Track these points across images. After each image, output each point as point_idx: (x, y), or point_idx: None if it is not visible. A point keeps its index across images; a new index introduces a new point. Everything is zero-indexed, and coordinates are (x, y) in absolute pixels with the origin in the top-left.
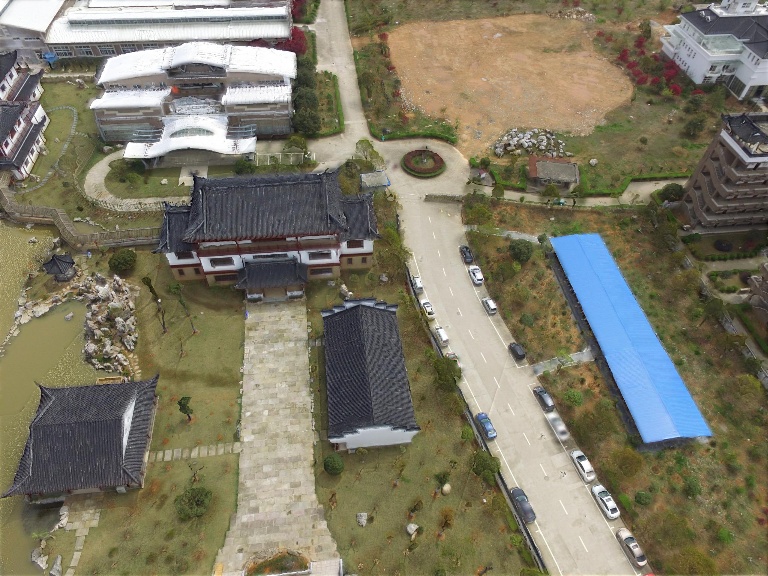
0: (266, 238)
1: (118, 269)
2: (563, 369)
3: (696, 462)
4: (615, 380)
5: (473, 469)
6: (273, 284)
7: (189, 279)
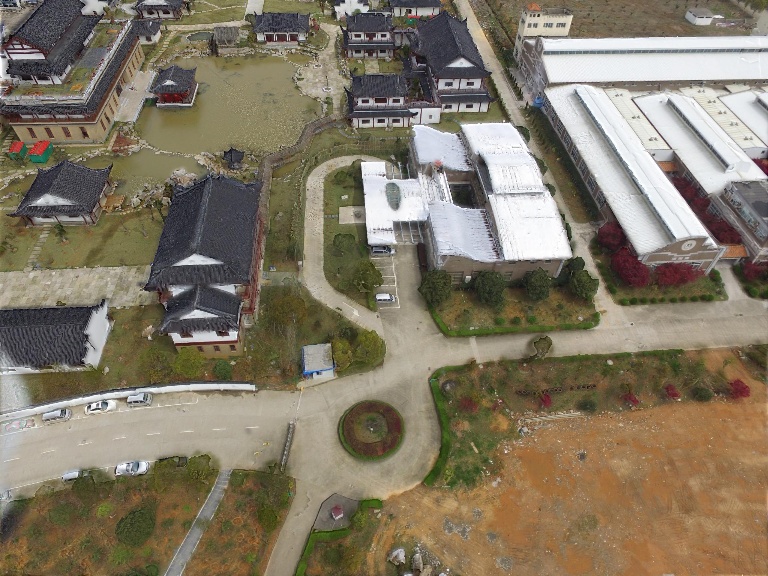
0: None
1: None
2: None
3: None
4: None
5: None
6: None
7: None
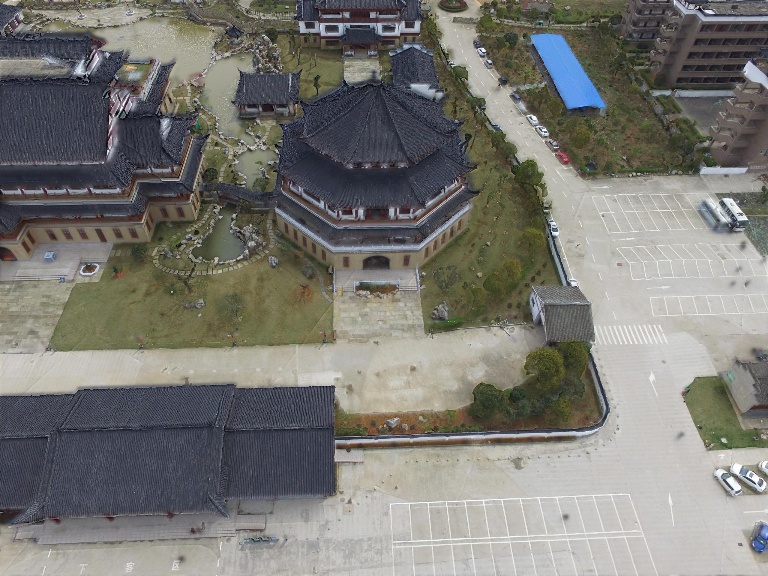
0: (360, 11)
1: None
2: None
3: (596, 122)
4: (557, 88)
5: (471, 106)
6: (361, 42)
7: None
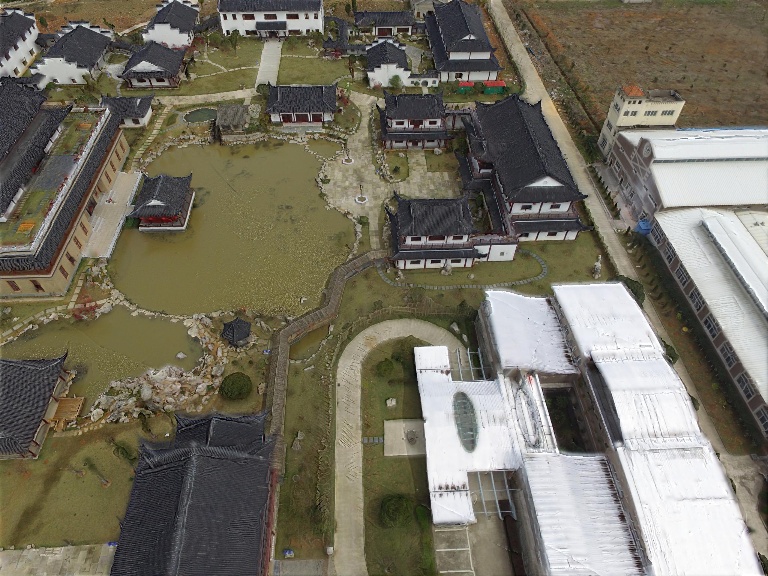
0: None
1: None
2: None
3: None
4: None
5: None
6: None
7: None
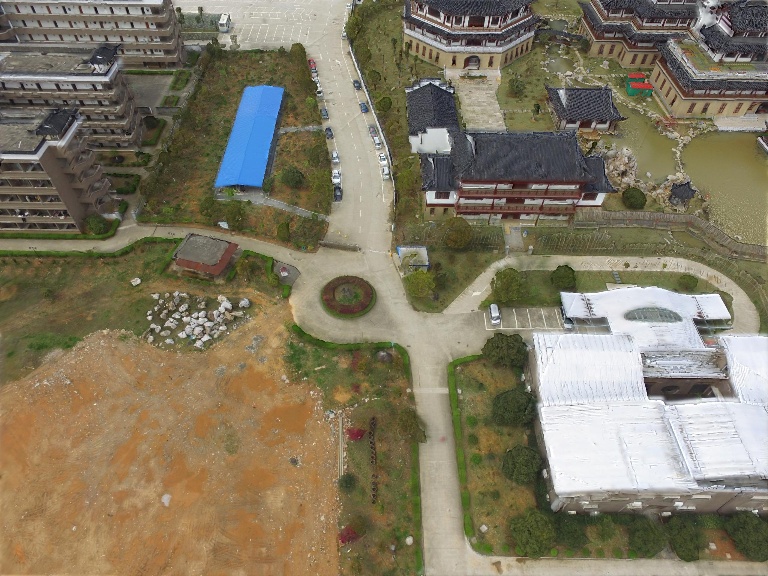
0: None
1: None
2: None
3: None
4: None
5: None
6: None
7: None
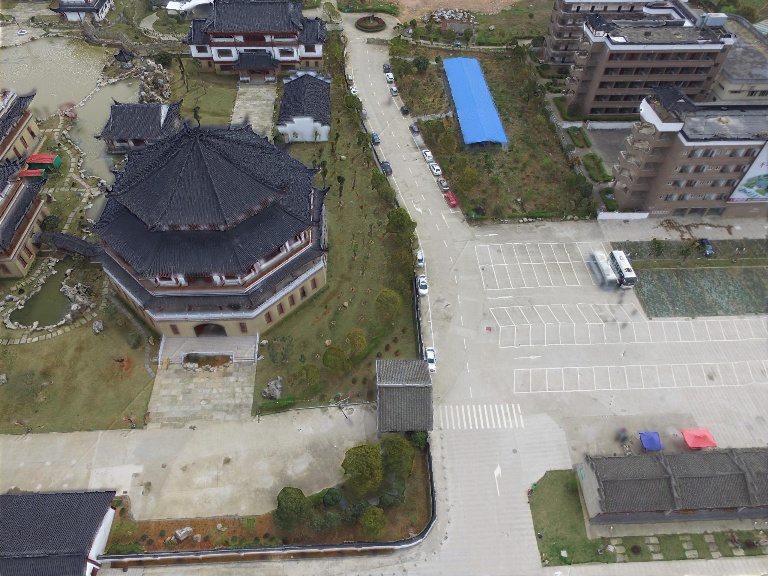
0: (252, 34)
1: (160, 62)
2: (431, 120)
3: (496, 158)
4: (459, 120)
5: None
6: (256, 67)
7: (204, 71)
